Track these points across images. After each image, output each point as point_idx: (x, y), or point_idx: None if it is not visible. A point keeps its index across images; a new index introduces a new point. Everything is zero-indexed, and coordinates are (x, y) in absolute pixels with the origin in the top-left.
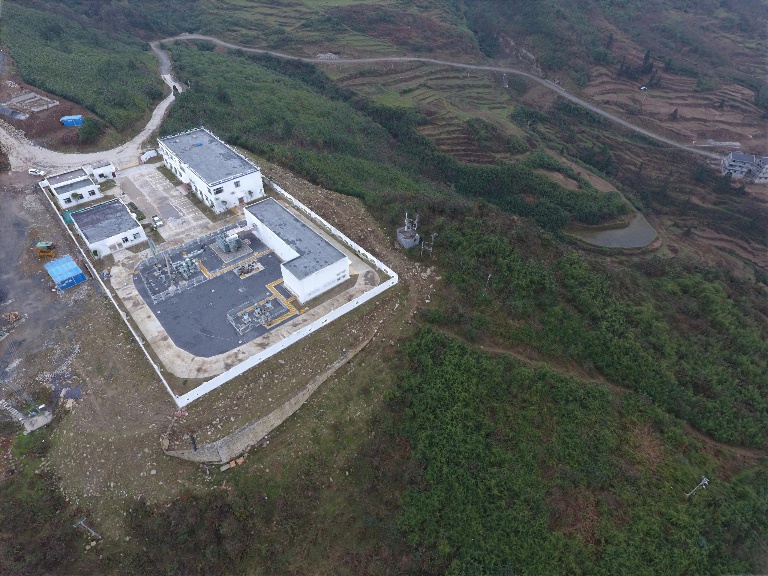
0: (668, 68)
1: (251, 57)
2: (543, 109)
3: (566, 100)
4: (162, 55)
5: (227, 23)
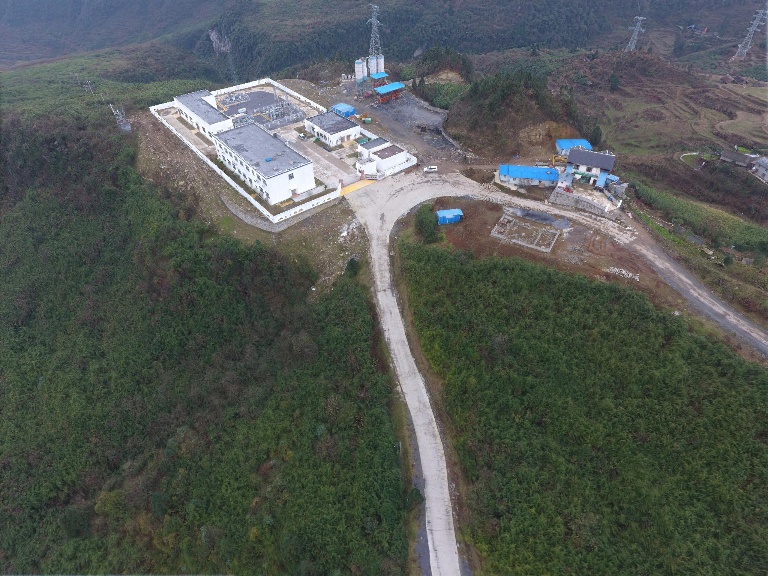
0: None
1: None
2: None
3: None
4: None
5: None
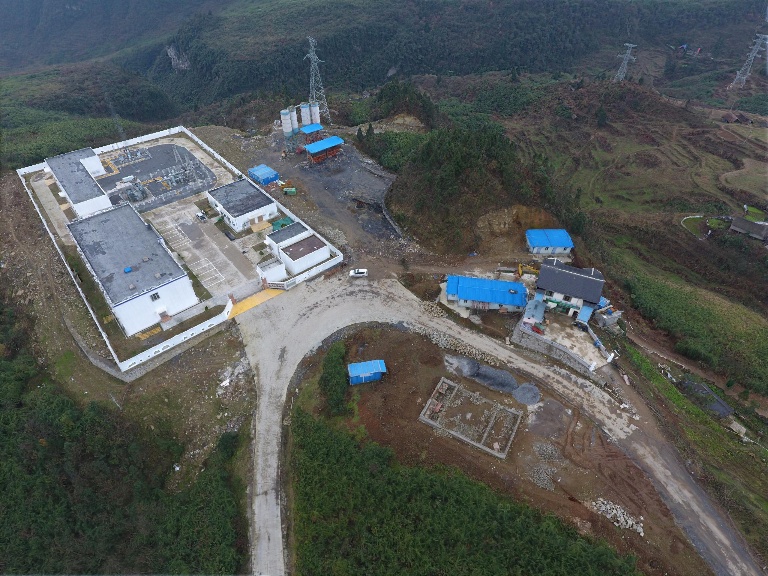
0: None
1: None
2: None
3: None
4: None
5: None
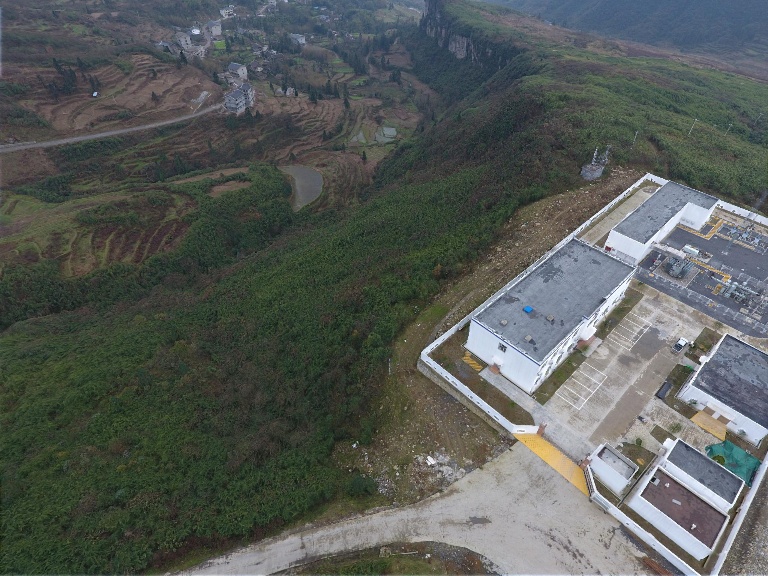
0: (85, 67)
1: None
2: (50, 172)
3: (62, 147)
4: None
5: None
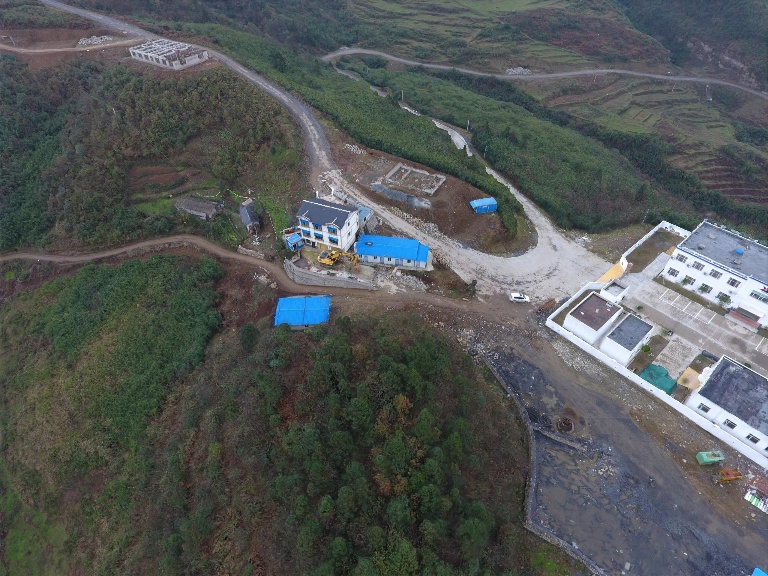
0: None
1: (436, 75)
2: None
3: None
4: (350, 77)
5: (392, 34)
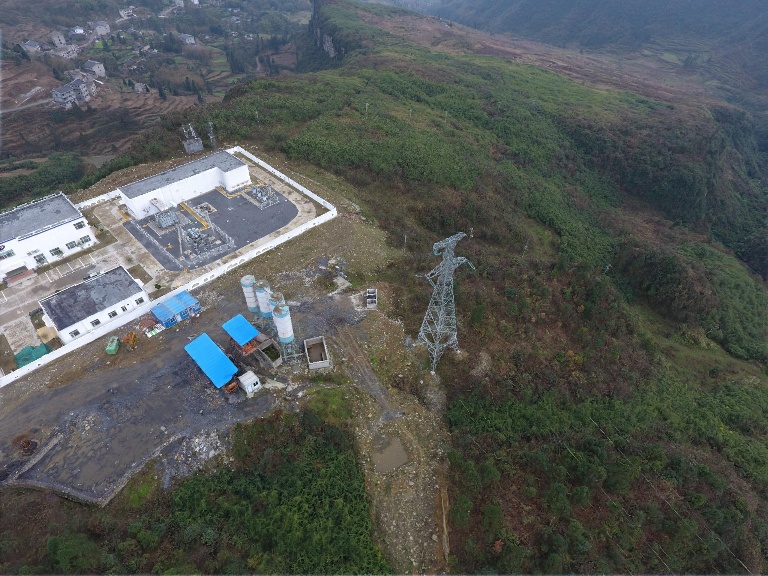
0: None
1: None
2: None
3: None
4: None
5: None
